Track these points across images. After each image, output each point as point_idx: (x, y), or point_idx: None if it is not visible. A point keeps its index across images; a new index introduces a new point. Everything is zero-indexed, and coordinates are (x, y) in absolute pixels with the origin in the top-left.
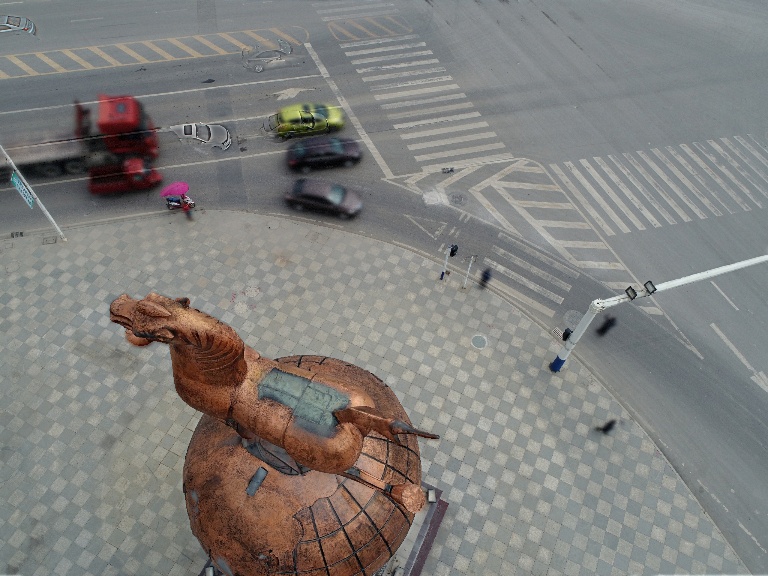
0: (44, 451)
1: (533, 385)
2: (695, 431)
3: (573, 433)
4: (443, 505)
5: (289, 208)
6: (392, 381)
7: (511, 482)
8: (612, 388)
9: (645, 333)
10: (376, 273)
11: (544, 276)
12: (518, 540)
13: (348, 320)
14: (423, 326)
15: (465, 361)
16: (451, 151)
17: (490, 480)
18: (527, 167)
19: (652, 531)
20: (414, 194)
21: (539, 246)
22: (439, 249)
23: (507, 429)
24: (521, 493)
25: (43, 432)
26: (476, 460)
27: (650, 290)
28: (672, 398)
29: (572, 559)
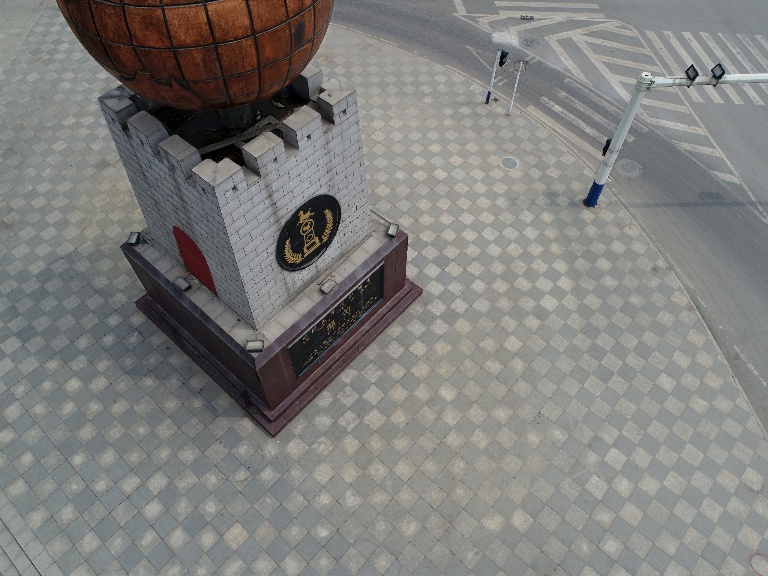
0: (42, 159)
1: (558, 213)
2: (746, 299)
3: (591, 265)
4: (416, 289)
5: (348, 22)
6: (401, 176)
7: (502, 291)
8: (654, 237)
9: (712, 196)
10: (418, 86)
11: (605, 124)
12: (491, 344)
13: (374, 117)
14: (452, 138)
15: (488, 176)
16: (536, 2)
17: (478, 283)
18: (618, 28)
19: (659, 377)
20: (483, 31)
21: (608, 97)
22: (494, 80)
23: (514, 244)
24: (510, 303)
25: (47, 145)
26: (469, 262)
27: (717, 74)
28: (726, 262)
29: (550, 378)
